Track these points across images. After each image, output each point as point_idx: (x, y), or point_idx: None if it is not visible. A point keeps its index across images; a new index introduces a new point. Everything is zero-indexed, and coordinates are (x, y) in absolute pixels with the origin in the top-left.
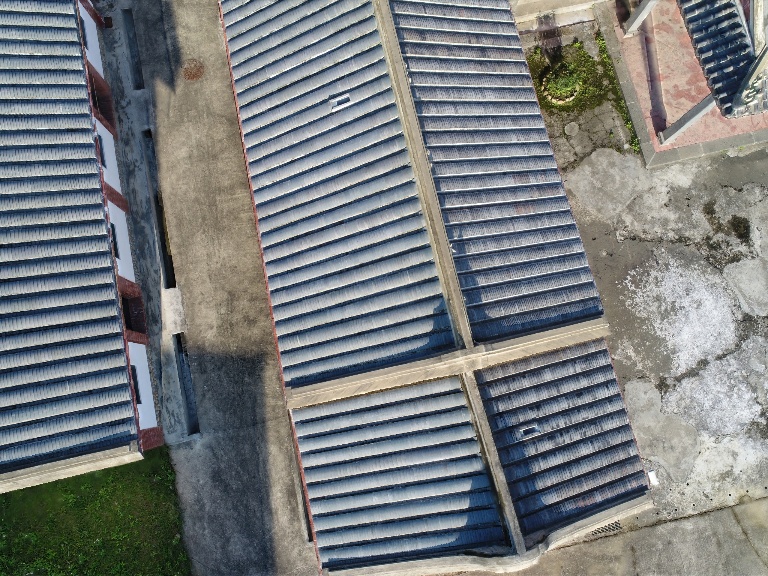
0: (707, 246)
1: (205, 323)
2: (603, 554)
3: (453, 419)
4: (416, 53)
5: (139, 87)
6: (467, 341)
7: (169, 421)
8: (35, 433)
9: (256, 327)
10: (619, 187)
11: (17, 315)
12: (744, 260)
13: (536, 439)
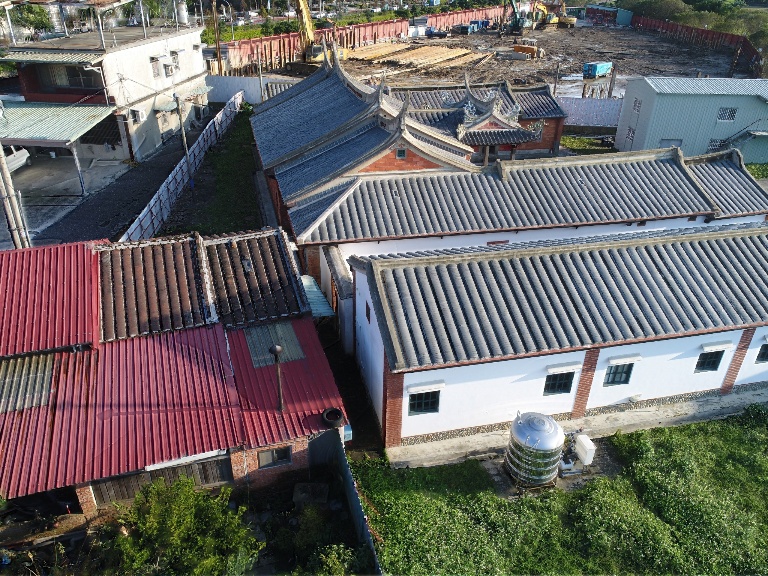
0: None
1: None
2: None
3: (696, 169)
4: None
5: None
6: None
7: None
8: None
9: None
10: None
11: None
12: None
13: None
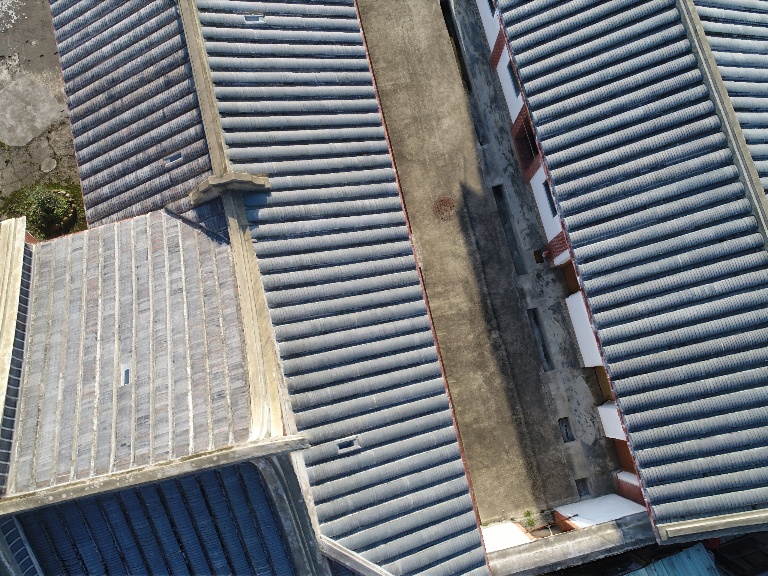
0: None
1: None
2: None
3: None
4: (174, 56)
5: (500, 197)
6: None
7: None
8: None
9: None
10: (8, 106)
11: None
12: None
13: None
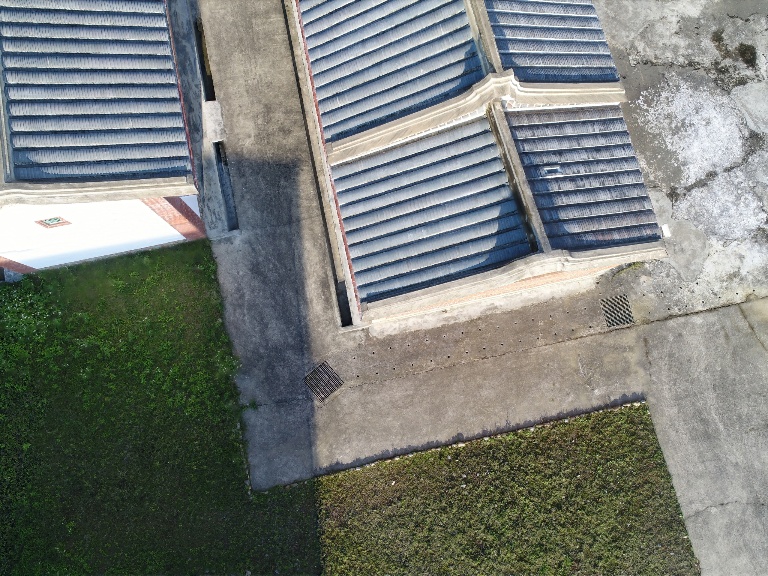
0: (715, 70)
1: (243, 132)
2: (617, 344)
3: (483, 156)
4: None
5: None
6: (497, 66)
7: (211, 218)
8: (102, 155)
9: (291, 136)
10: (632, 17)
11: (84, 56)
12: (751, 83)
13: (559, 179)
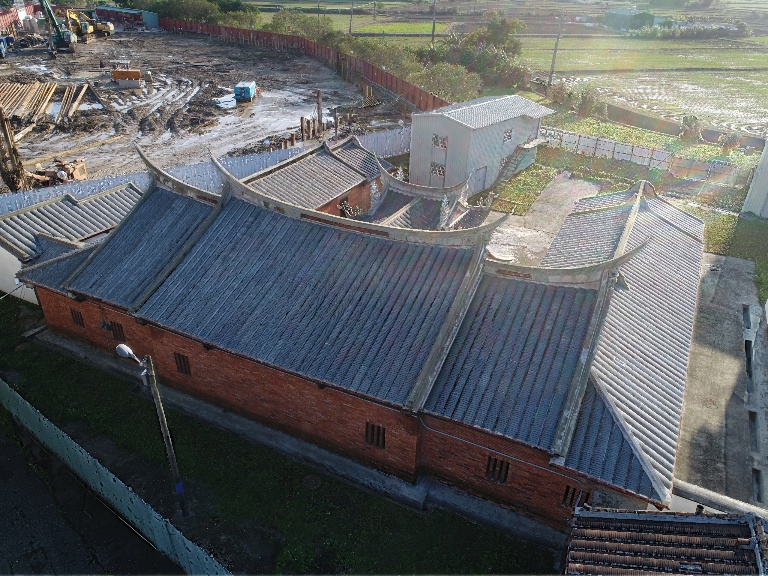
0: None
1: None
2: None
3: None
4: None
5: (753, 421)
6: (639, 196)
7: (759, 311)
8: None
9: None
10: None
11: None
12: None
13: None
